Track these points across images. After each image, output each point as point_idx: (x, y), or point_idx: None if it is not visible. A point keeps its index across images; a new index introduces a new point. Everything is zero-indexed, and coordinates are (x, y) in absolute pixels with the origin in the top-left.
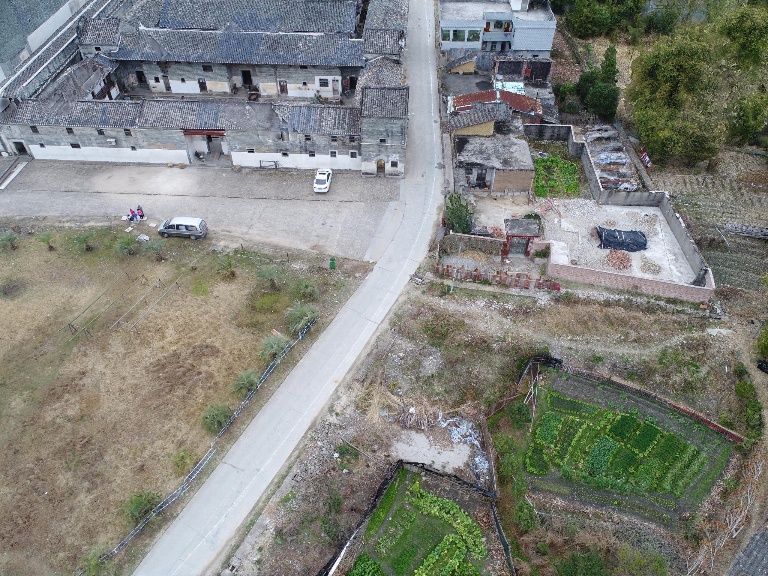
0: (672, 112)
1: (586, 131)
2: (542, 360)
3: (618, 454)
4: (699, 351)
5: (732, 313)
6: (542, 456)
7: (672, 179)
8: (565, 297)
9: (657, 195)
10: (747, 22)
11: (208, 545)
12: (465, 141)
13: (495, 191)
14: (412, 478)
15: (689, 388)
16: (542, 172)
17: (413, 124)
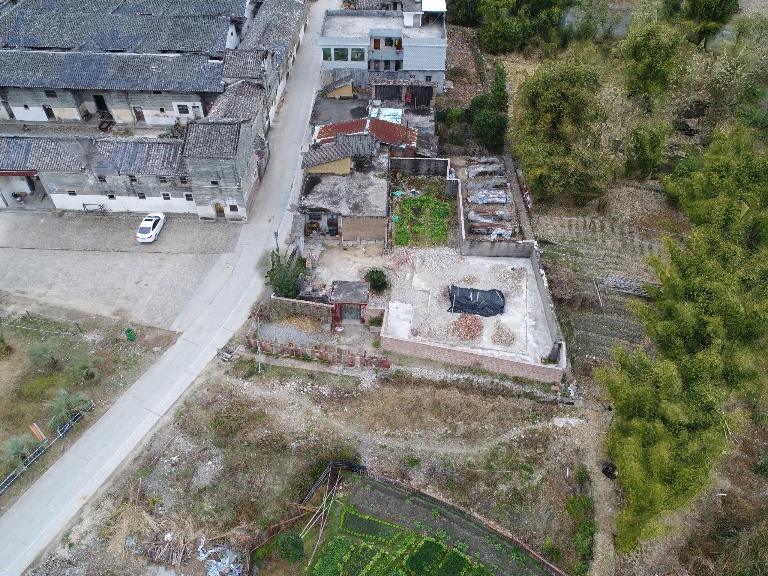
0: (553, 146)
1: (471, 164)
2: (344, 464)
3: None
4: (537, 449)
5: (588, 396)
6: None
7: (557, 221)
8: (396, 376)
9: (526, 245)
10: (651, 41)
11: None
12: (317, 181)
13: (346, 239)
14: None
15: (517, 500)
16: (409, 214)
17: (276, 157)
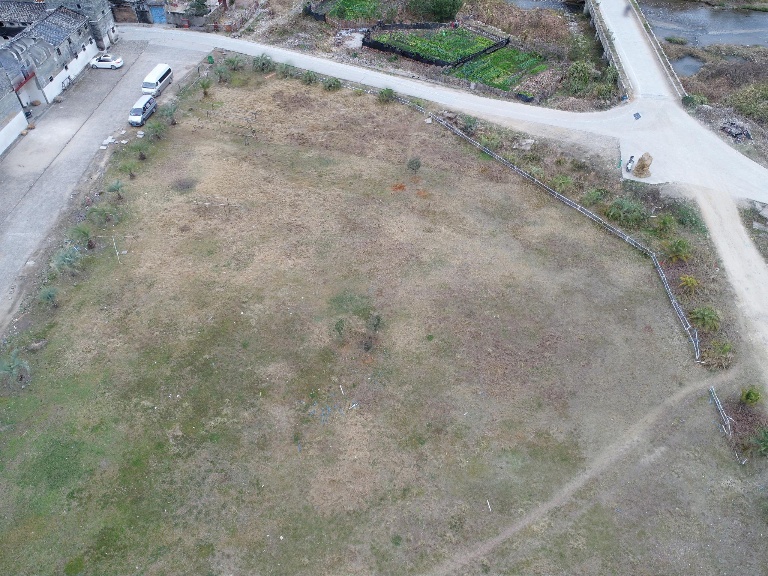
0: None
1: None
2: None
3: None
4: None
5: None
6: None
7: None
8: (262, 7)
9: None
10: None
11: (403, 82)
12: None
13: None
14: None
15: None
16: None
17: None
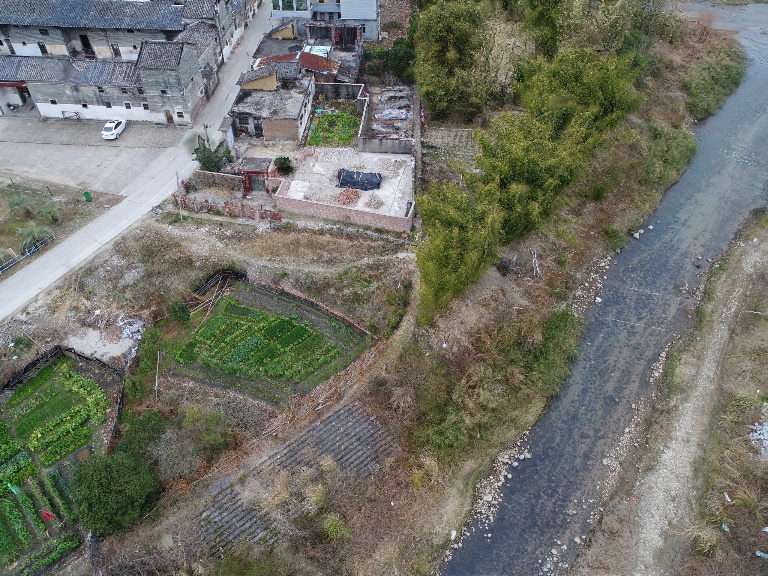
0: (440, 70)
1: None
2: (233, 275)
3: (262, 349)
4: (379, 270)
5: None
6: (194, 349)
7: (445, 133)
8: (286, 227)
9: (407, 143)
10: None
11: None
12: (248, 95)
13: (268, 139)
14: (71, 364)
15: (357, 300)
16: (325, 125)
17: (225, 84)
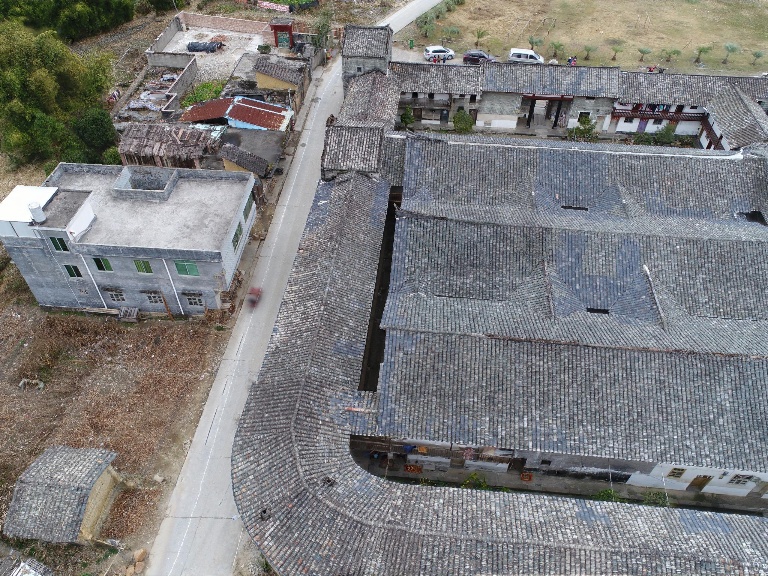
0: None
1: None
2: None
3: None
4: None
5: None
6: None
7: None
8: None
9: (153, 55)
10: None
11: None
12: None
13: None
14: None
15: None
16: None
17: None
